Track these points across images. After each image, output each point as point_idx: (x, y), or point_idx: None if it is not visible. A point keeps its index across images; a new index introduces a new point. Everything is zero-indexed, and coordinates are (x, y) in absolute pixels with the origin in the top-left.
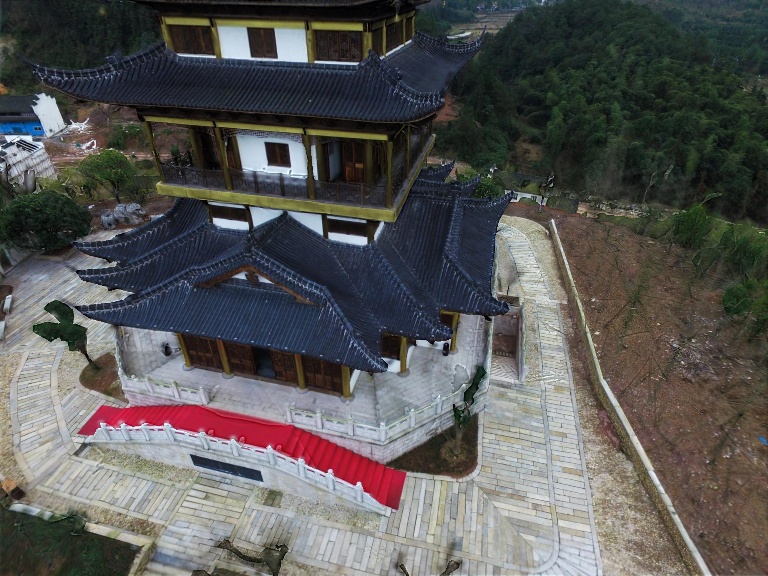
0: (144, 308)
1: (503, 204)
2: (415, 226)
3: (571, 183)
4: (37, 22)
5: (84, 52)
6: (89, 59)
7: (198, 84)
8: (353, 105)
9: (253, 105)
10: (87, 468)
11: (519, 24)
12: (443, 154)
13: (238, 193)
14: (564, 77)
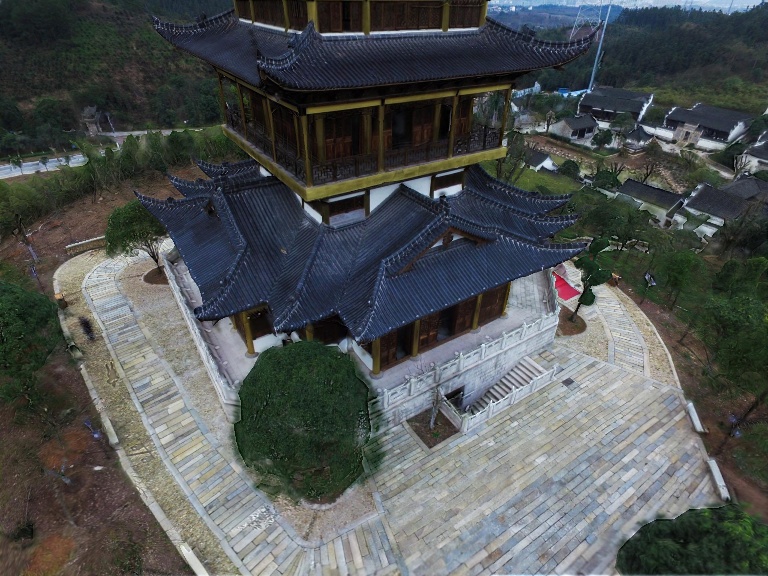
0: None
1: None
2: None
3: None
4: None
5: None
6: None
7: None
8: None
9: None
10: (572, 277)
11: None
12: None
13: None
14: None
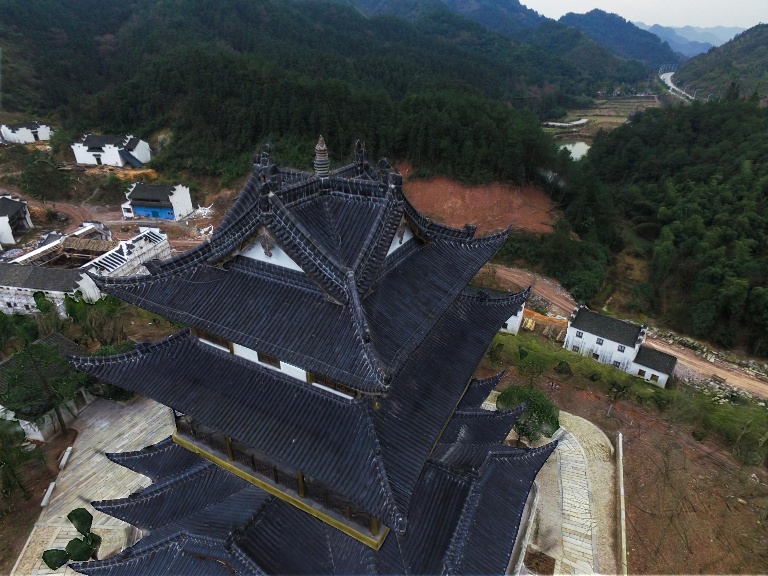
0: (132, 567)
1: (543, 454)
2: (423, 505)
3: (675, 319)
4: (191, 120)
5: (221, 147)
6: (224, 152)
7: (205, 383)
8: (331, 462)
9: (240, 433)
10: None
11: (636, 125)
12: (532, 267)
13: (237, 468)
14: (681, 189)
